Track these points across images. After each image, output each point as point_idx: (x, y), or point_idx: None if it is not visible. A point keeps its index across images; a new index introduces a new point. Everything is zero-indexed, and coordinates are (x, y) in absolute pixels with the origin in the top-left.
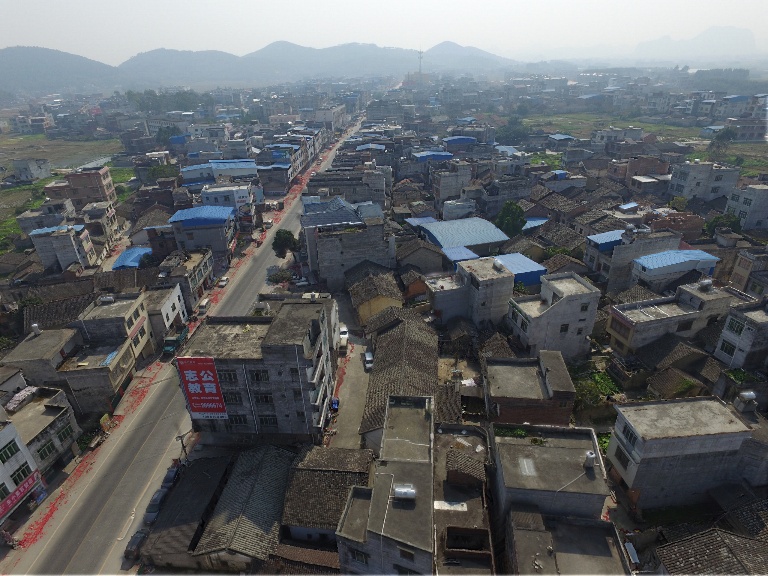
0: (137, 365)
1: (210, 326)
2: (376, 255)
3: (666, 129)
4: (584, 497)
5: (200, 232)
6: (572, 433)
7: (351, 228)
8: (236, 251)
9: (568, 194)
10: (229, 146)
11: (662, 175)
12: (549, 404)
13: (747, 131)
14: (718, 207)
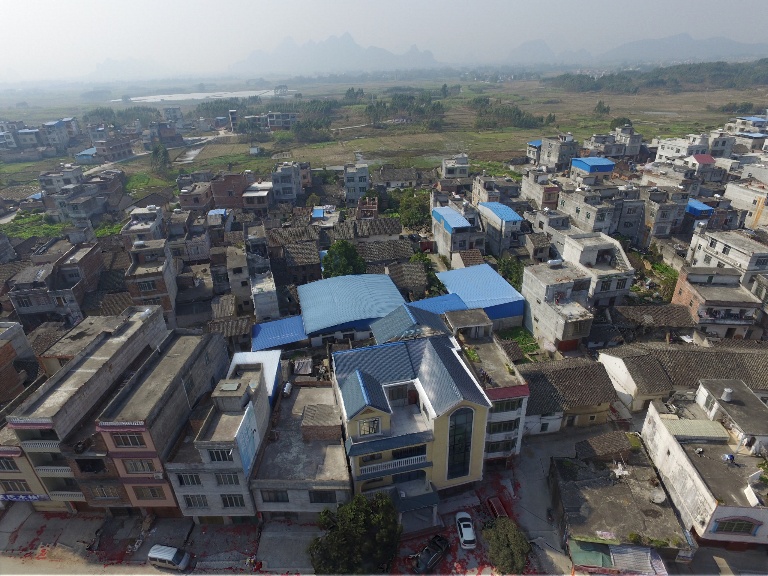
0: None
1: None
2: None
3: (25, 167)
4: None
5: None
6: None
7: (466, 353)
8: None
9: None
10: None
11: None
12: None
13: (120, 150)
14: (318, 195)
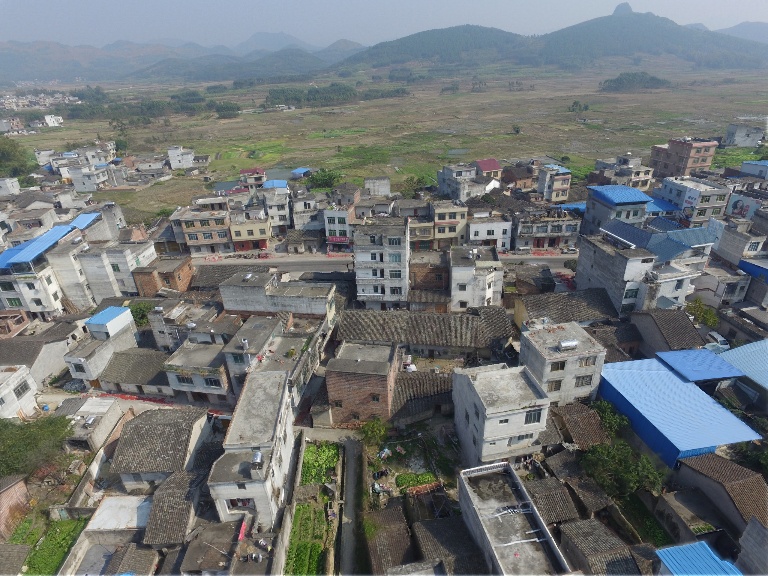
0: (444, 247)
1: None
2: (614, 290)
3: None
4: None
5: (599, 206)
6: None
7: None
8: None
9: None
10: None
11: None
12: None
13: None
14: None
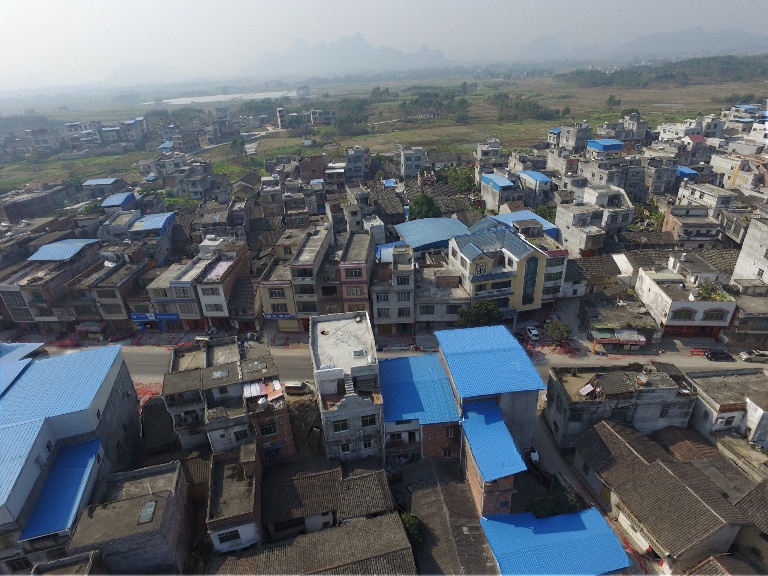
0: None
1: None
2: None
3: (115, 158)
4: None
5: None
6: None
7: None
8: None
9: None
10: None
11: None
12: None
13: (192, 144)
14: None
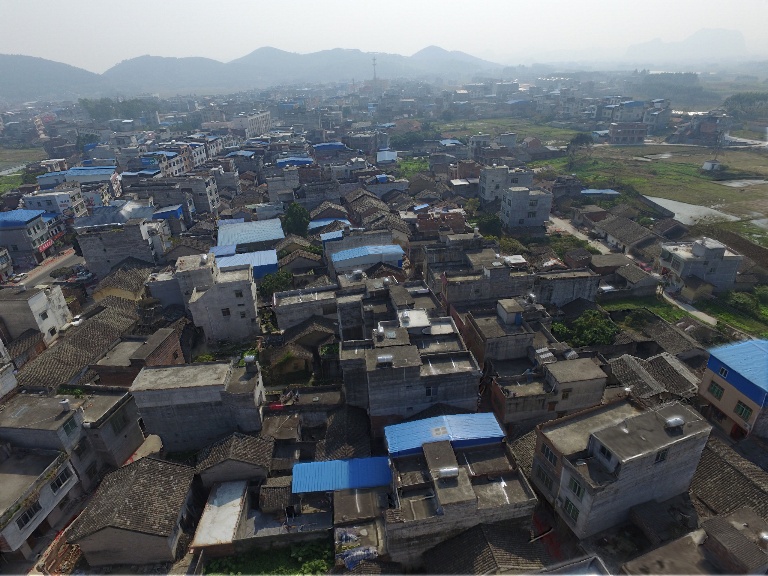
0: None
1: None
2: (139, 252)
3: (565, 133)
4: (43, 433)
5: (3, 233)
6: (119, 391)
7: (118, 228)
8: (57, 251)
9: (387, 196)
10: (123, 153)
11: (478, 178)
12: (131, 370)
13: (628, 135)
14: None
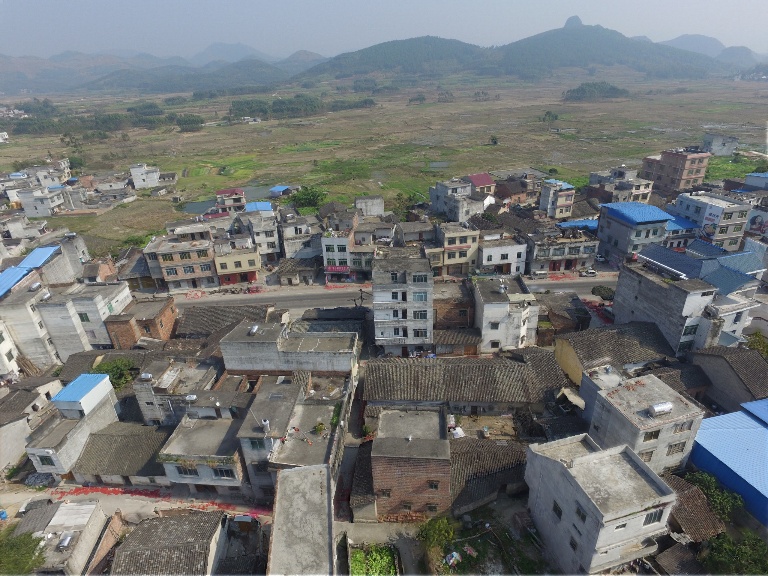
0: (453, 273)
1: (418, 251)
2: (667, 326)
3: None
4: None
5: (616, 225)
6: None
7: None
8: None
9: None
10: None
11: None
12: None
13: None
14: None
